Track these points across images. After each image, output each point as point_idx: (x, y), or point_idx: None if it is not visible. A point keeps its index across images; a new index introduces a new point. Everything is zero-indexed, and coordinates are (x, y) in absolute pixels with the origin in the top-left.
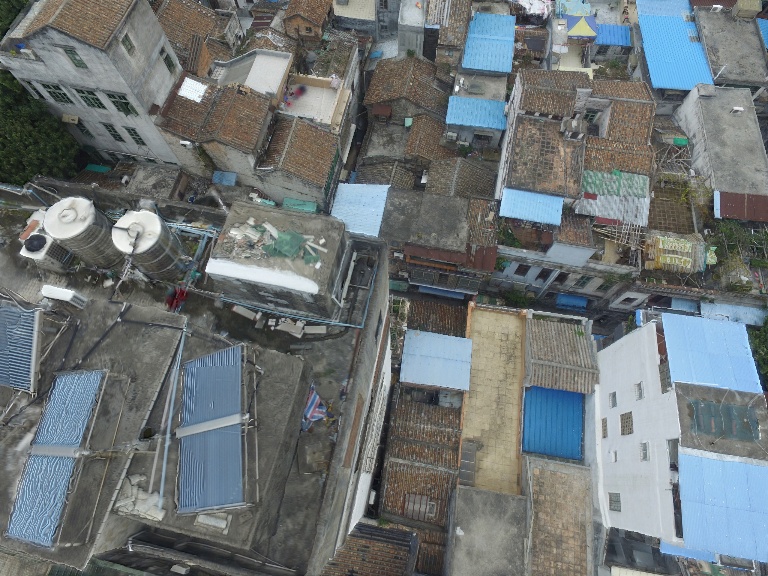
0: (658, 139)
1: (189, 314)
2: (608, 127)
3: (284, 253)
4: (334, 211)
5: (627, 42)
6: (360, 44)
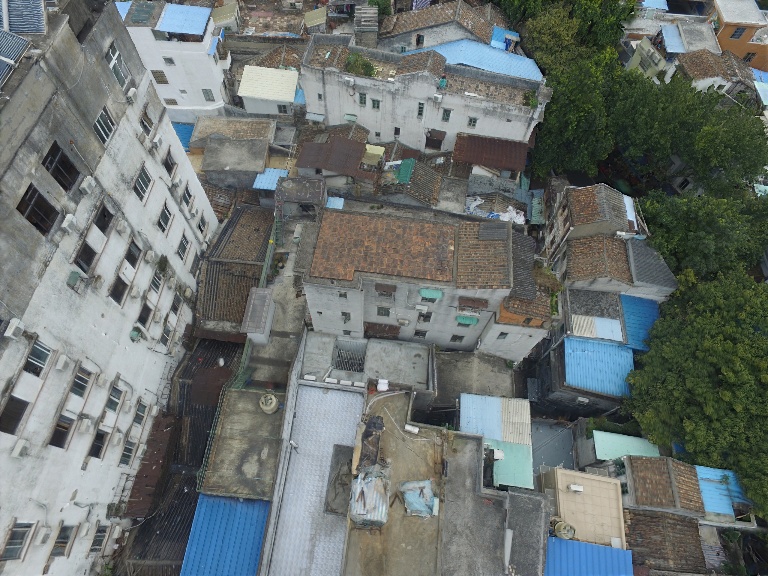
0: None
1: None
2: None
3: None
4: None
5: None
6: None
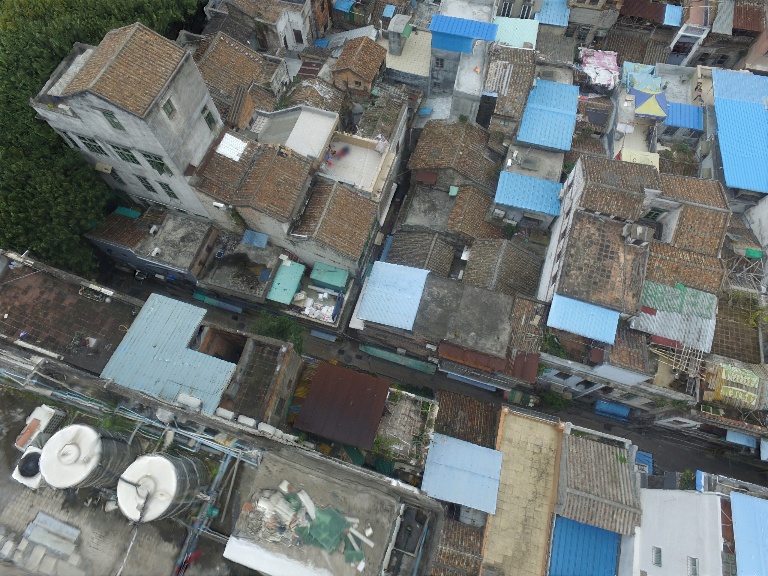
0: (727, 245)
1: (200, 564)
2: (675, 233)
3: (321, 543)
4: (367, 292)
5: (699, 125)
6: (410, 102)
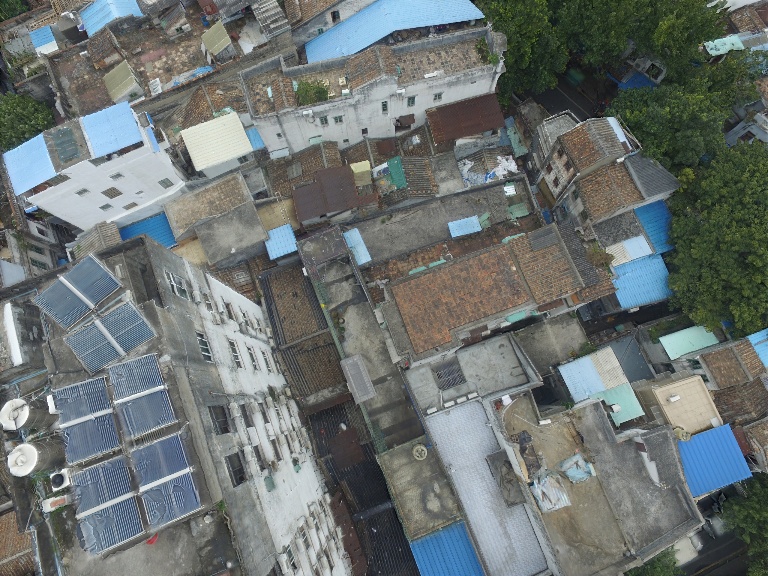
0: None
1: None
2: None
3: None
4: None
5: None
6: None
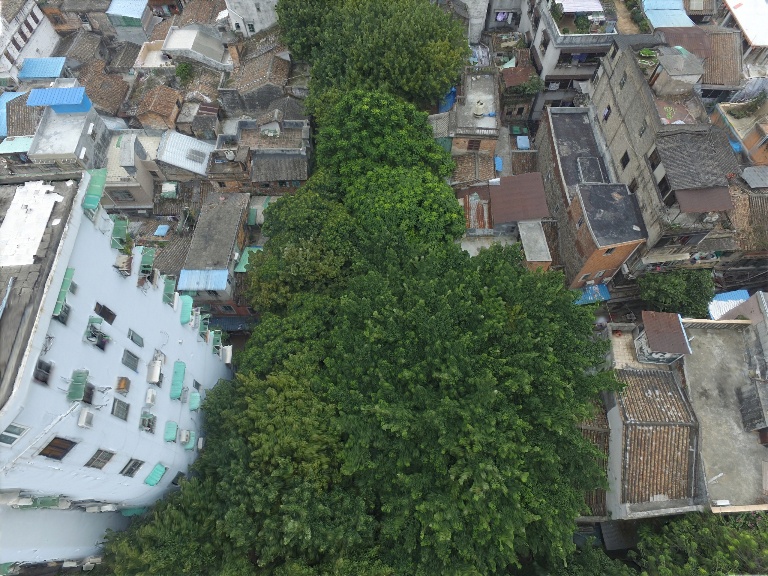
0: None
1: None
2: None
3: None
4: (144, 6)
5: None
6: (124, 111)
